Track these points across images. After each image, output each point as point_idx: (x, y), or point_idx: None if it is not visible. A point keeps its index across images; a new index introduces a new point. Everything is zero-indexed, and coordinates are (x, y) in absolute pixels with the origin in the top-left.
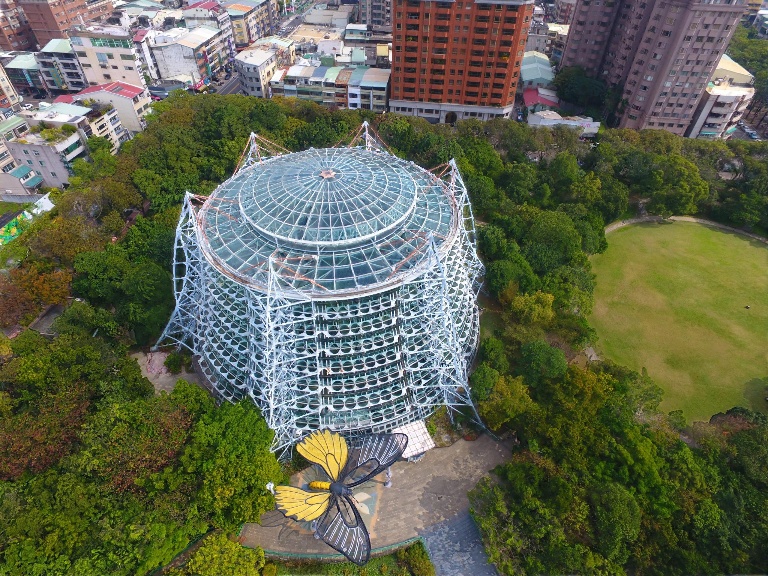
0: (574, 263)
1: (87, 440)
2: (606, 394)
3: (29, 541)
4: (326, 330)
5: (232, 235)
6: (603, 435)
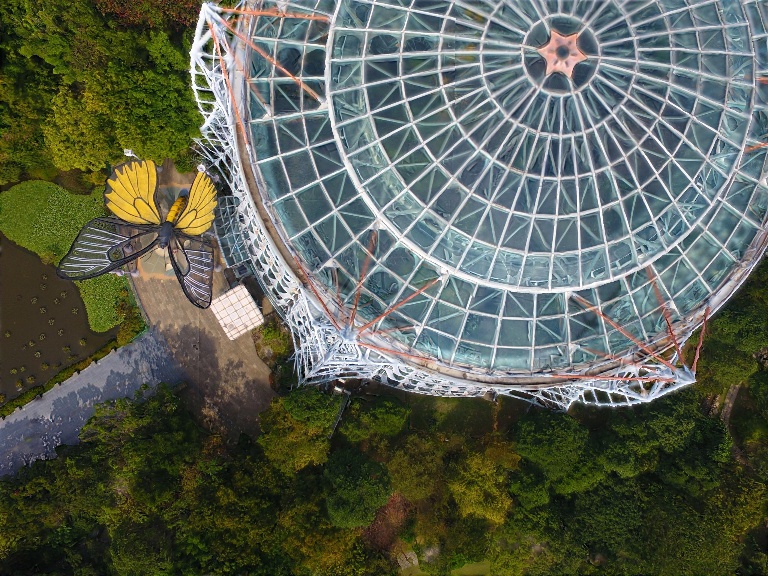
0: (589, 571)
1: None
2: (326, 568)
3: None
4: None
5: None
6: (242, 556)
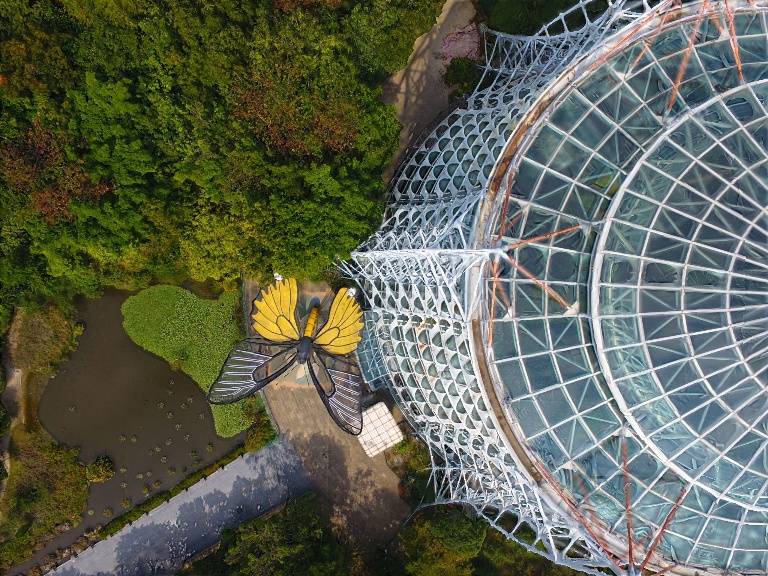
0: None
1: (282, 31)
2: None
3: (166, 37)
4: (455, 331)
5: (630, 108)
6: None
